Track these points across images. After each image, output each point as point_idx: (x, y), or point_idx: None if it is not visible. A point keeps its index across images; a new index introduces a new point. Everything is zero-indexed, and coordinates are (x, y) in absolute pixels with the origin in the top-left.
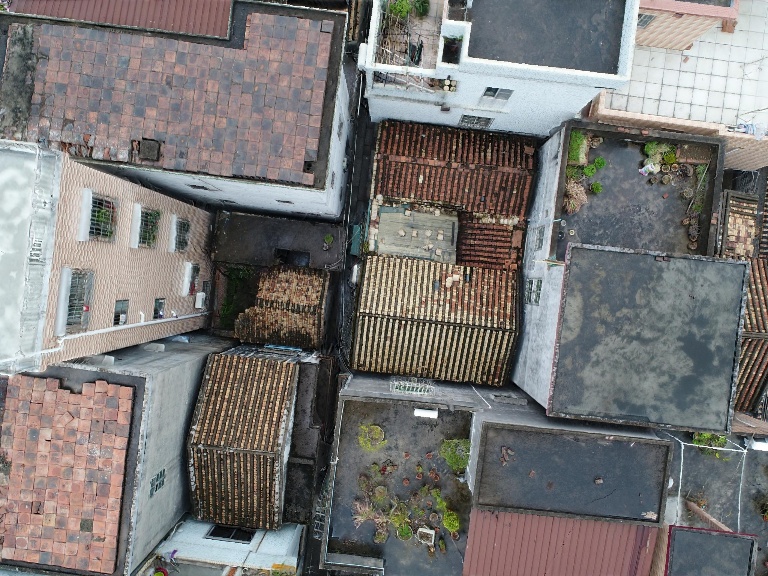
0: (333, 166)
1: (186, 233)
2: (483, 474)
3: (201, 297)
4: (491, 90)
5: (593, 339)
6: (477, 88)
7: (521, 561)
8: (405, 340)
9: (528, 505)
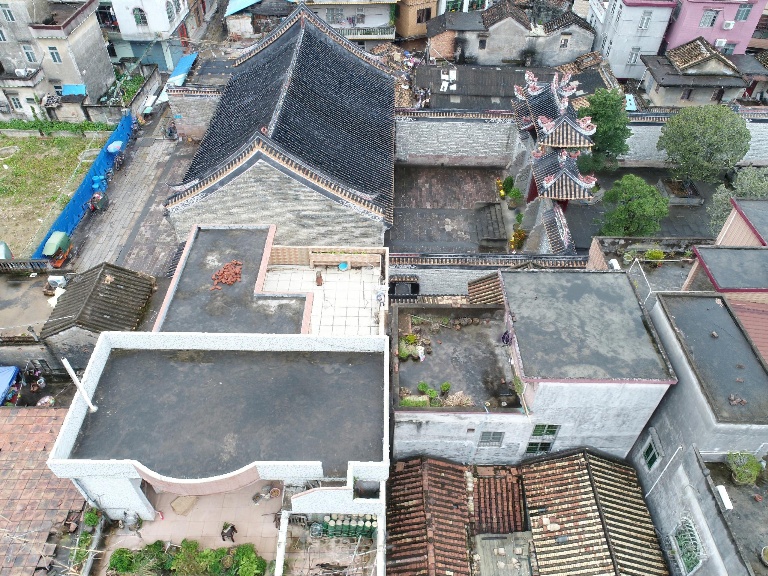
0: None
1: None
2: None
3: None
4: None
5: (596, 356)
6: None
7: None
8: (634, 567)
9: (767, 381)
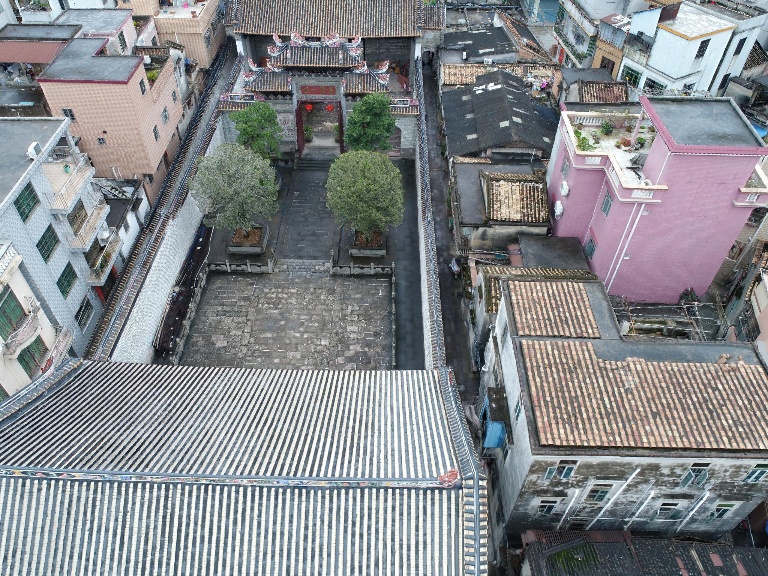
0: None
1: None
2: (1, 32)
3: None
4: (61, 3)
5: None
6: (55, 1)
7: (8, 53)
8: None
9: None
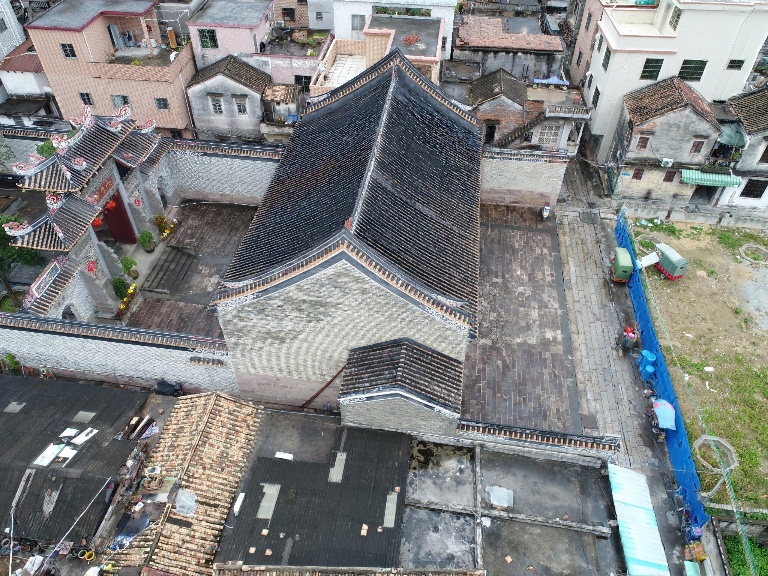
0: (324, 13)
1: (305, 3)
2: None
3: (282, 22)
4: None
5: (236, 3)
6: None
7: None
8: None
9: None
